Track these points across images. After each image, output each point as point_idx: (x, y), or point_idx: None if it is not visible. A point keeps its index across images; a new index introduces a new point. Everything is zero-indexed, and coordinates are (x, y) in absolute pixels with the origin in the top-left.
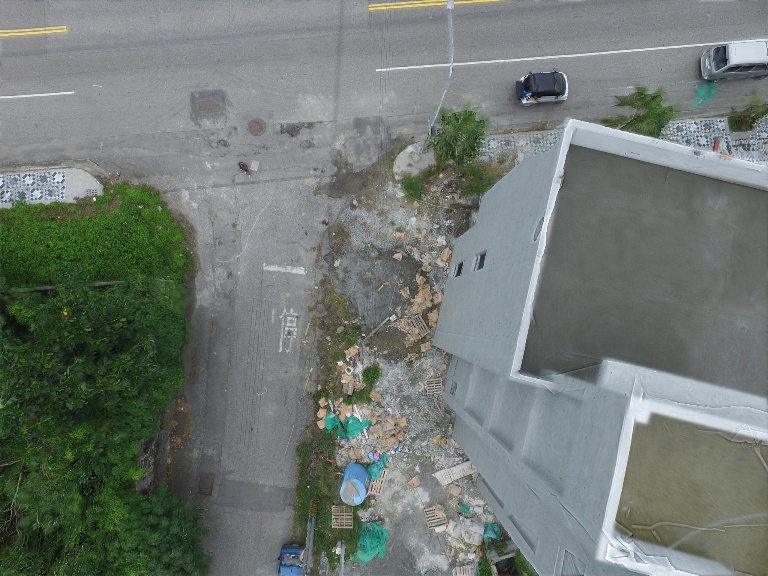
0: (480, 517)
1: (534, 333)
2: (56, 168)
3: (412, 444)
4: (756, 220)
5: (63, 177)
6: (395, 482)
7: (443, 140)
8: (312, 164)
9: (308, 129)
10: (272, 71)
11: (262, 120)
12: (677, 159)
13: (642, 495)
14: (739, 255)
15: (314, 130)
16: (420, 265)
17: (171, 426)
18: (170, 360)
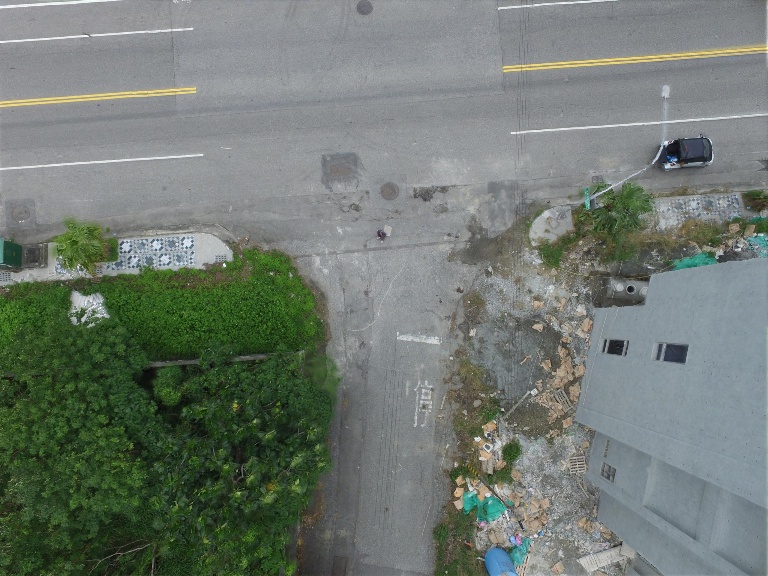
0: None
1: None
2: (184, 233)
3: (555, 527)
4: None
5: (192, 242)
6: (538, 568)
7: (604, 214)
8: (446, 229)
9: (442, 193)
10: (405, 134)
11: (395, 184)
12: None
13: None
14: None
15: (448, 194)
16: (560, 336)
17: (301, 505)
18: None
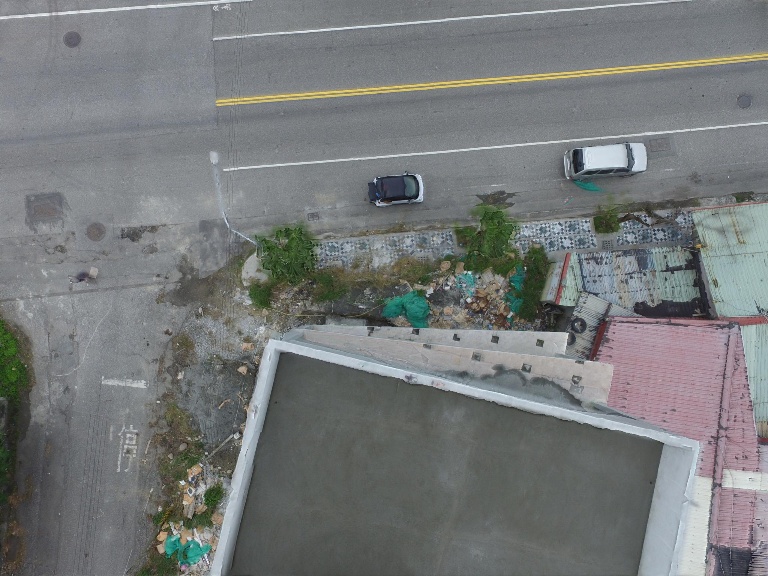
0: None
1: None
2: None
3: None
4: (495, 433)
5: None
6: None
7: None
8: (155, 270)
9: (151, 233)
10: (112, 172)
11: (101, 224)
12: None
13: None
14: (475, 473)
15: (157, 234)
16: None
17: (1, 552)
18: None
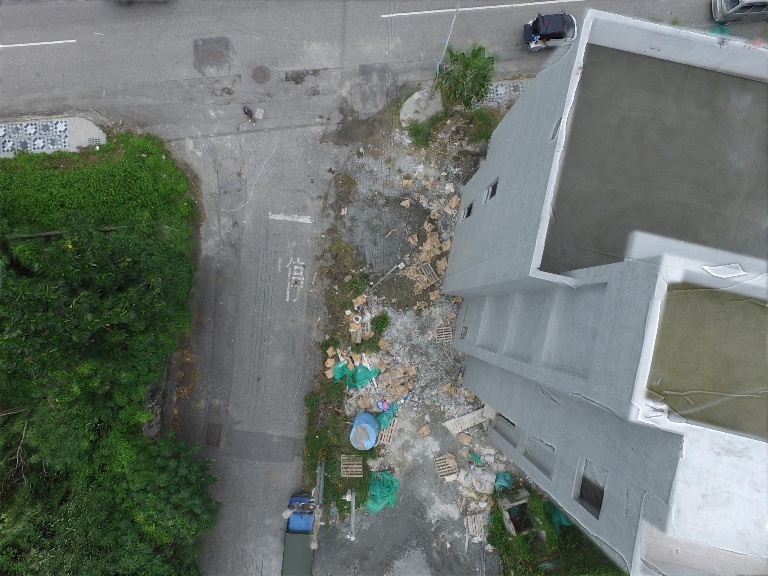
0: (491, 466)
1: (554, 230)
2: (58, 117)
3: (422, 393)
4: None
5: (65, 126)
6: (405, 431)
7: (452, 78)
8: (318, 112)
9: (313, 76)
10: (276, 17)
11: (266, 67)
12: (699, 53)
13: (672, 369)
14: (763, 154)
15: (319, 77)
16: (428, 213)
17: (178, 377)
18: (176, 304)
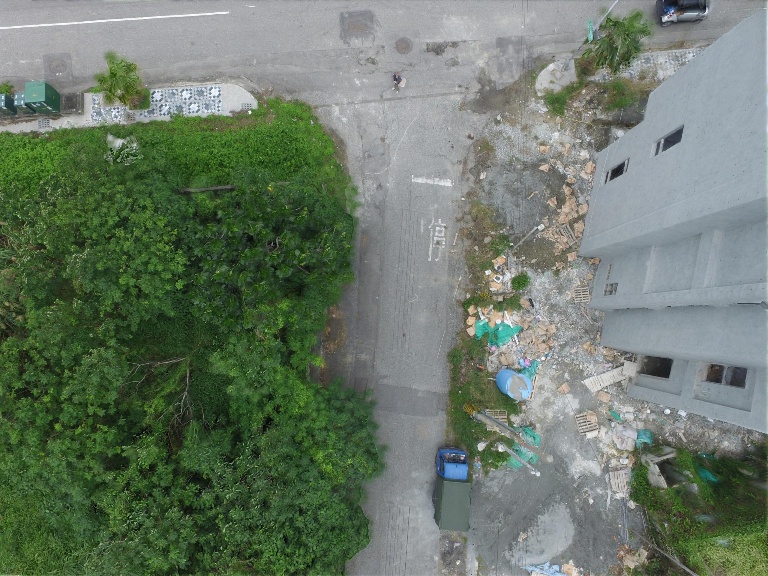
0: (631, 424)
1: None
2: (212, 83)
3: (561, 351)
4: None
5: (219, 92)
6: (545, 388)
7: (605, 43)
8: (457, 81)
9: (453, 48)
10: None
11: (409, 39)
12: None
13: None
14: None
15: (458, 49)
16: (565, 177)
17: (324, 332)
18: None
